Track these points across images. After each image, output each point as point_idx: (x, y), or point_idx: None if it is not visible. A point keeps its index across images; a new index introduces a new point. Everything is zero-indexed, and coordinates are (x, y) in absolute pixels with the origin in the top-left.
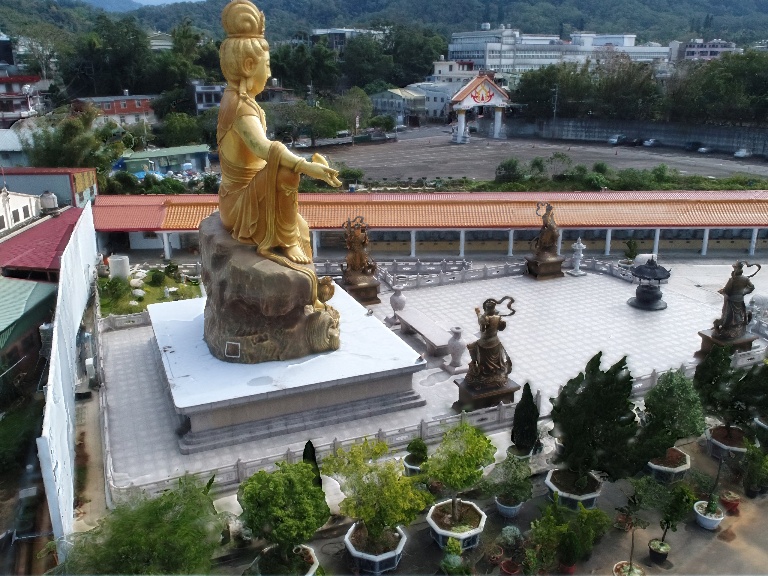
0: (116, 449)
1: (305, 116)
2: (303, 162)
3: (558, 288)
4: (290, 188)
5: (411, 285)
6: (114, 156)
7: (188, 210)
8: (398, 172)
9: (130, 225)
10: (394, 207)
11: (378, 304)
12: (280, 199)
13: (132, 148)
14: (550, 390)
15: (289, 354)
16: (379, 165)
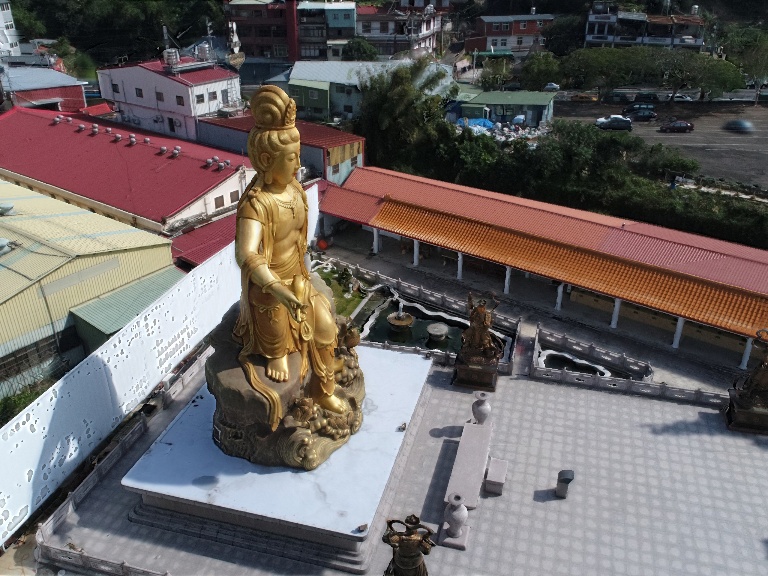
0: (102, 485)
1: (688, 68)
2: (271, 286)
3: (741, 456)
4: (264, 306)
5: (553, 377)
6: (429, 109)
7: (401, 210)
8: (763, 166)
9: (347, 214)
10: (606, 262)
11: (489, 393)
12: (257, 313)
13: (486, 87)
14: None
15: (258, 459)
16: (751, 148)
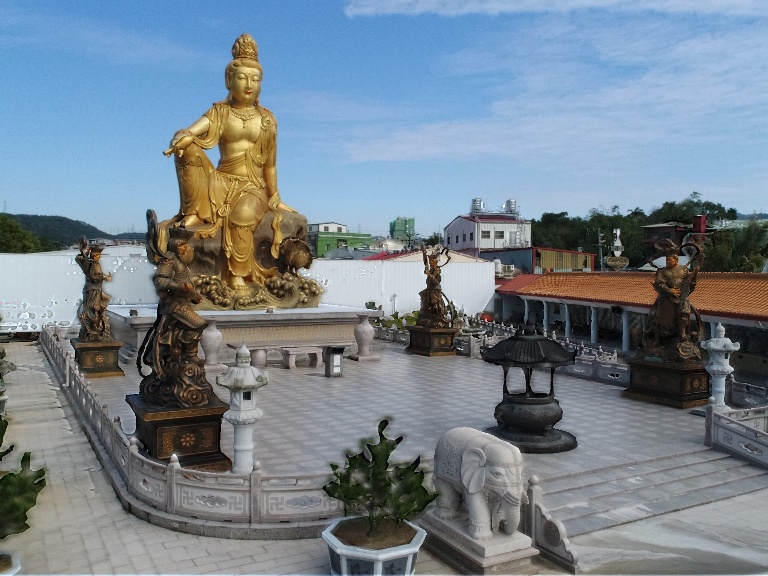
0: None
1: None
2: None
3: (581, 402)
4: None
5: None
6: None
7: (548, 279)
8: None
9: (510, 288)
10: None
11: (423, 356)
12: None
13: None
14: (125, 387)
15: None
16: None
